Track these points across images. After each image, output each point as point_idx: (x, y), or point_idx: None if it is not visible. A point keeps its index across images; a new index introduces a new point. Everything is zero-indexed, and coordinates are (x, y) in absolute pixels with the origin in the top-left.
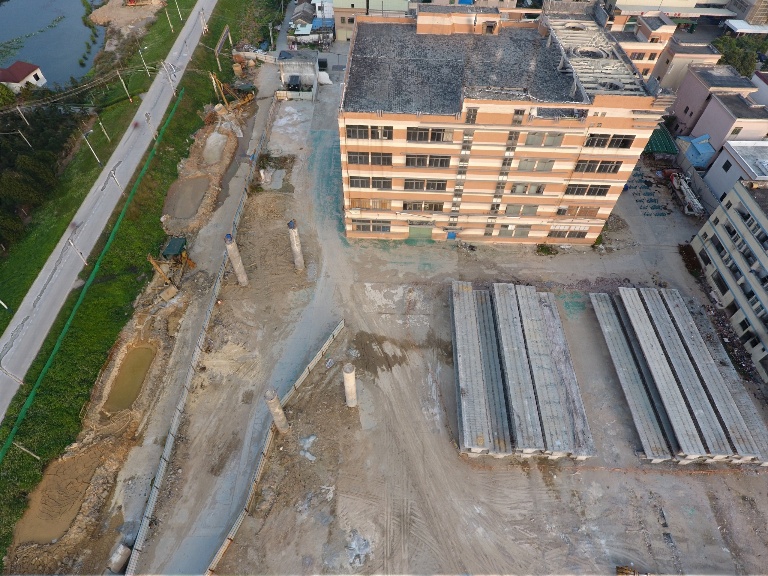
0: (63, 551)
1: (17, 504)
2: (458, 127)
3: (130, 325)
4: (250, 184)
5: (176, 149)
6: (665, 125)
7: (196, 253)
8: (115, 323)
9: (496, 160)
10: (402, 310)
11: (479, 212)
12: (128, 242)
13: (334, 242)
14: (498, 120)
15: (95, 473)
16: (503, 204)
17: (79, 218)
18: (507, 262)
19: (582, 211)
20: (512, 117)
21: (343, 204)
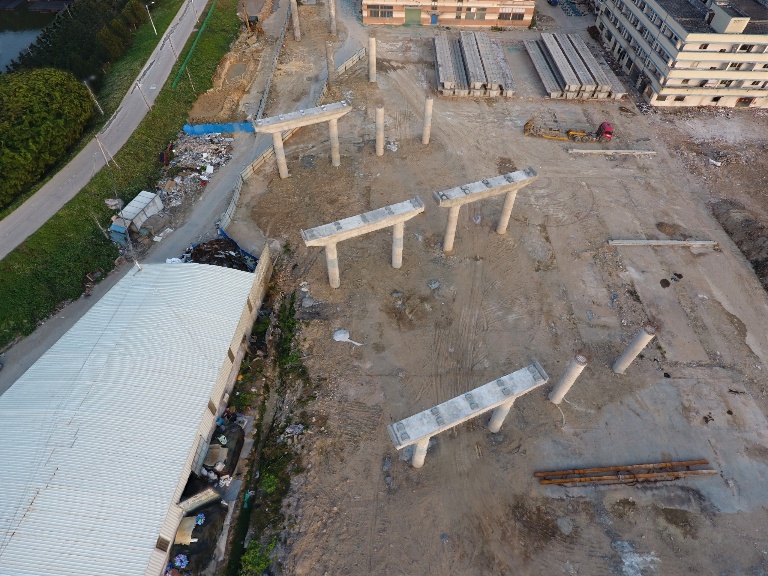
0: (218, 119)
1: (188, 104)
2: None
3: (230, 53)
4: None
5: None
6: None
7: (263, 30)
8: (221, 51)
9: None
10: (402, 50)
11: None
12: (220, 19)
13: (355, 25)
14: None
15: (227, 97)
16: None
17: (185, 7)
18: None
19: None
20: None
21: (359, 10)
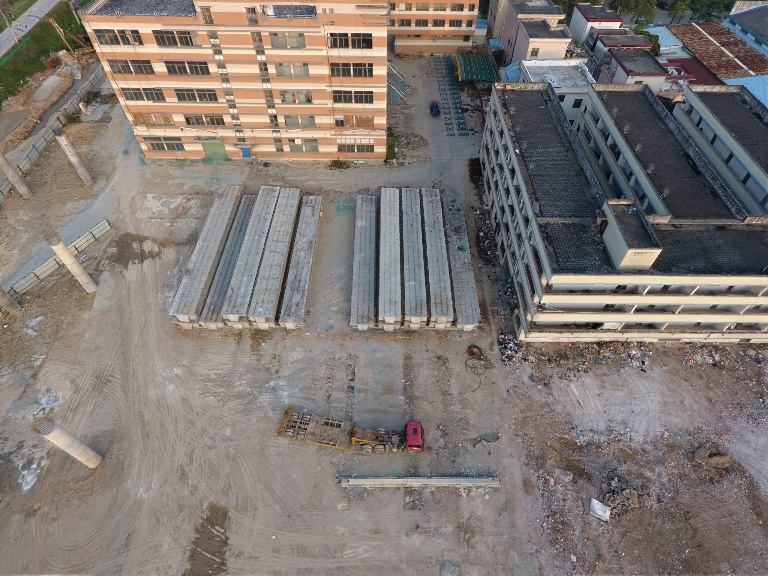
0: None
1: None
2: (200, 29)
3: None
4: (65, 114)
5: (5, 88)
6: (495, 59)
7: None
8: None
9: (252, 65)
10: (174, 215)
11: (261, 125)
12: None
13: (131, 162)
14: (234, 20)
15: None
16: (280, 115)
17: None
18: (296, 175)
19: (359, 121)
20: (246, 16)
21: None
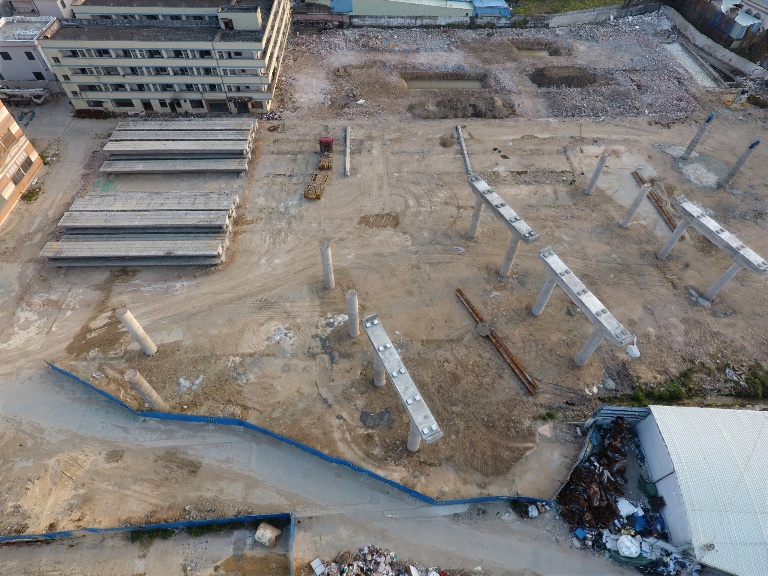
0: None
1: None
2: None
3: None
4: None
5: None
6: None
7: None
8: None
9: None
10: (53, 312)
11: None
12: None
13: None
14: None
15: None
16: None
17: None
18: (31, 224)
19: (4, 142)
20: None
21: None
